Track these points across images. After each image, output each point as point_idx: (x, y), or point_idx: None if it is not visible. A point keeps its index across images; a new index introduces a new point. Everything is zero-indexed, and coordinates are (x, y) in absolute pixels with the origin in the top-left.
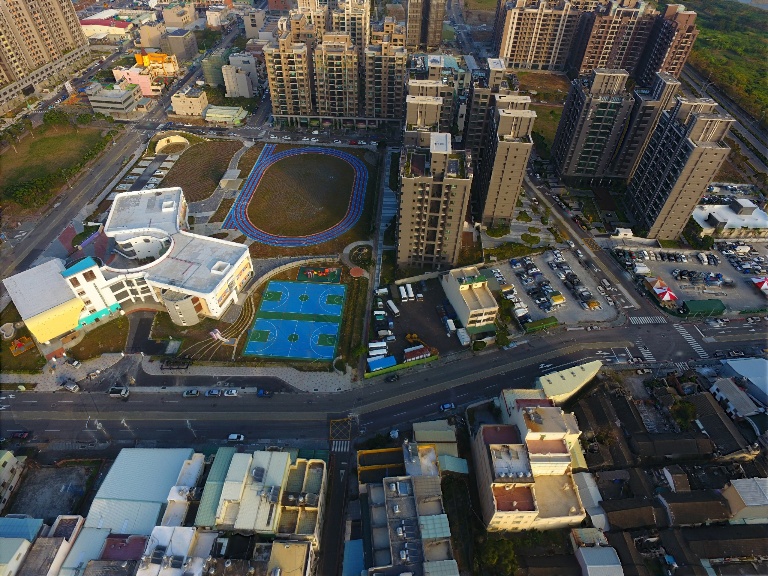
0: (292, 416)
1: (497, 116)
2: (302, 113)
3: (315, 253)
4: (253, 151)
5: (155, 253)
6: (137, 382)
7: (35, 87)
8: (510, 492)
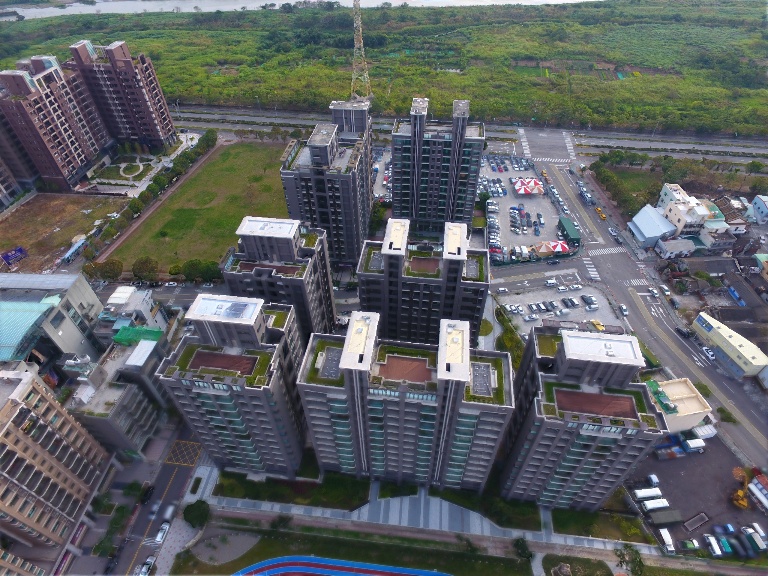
0: None
1: None
2: None
3: None
4: None
5: None
6: None
7: None
8: None
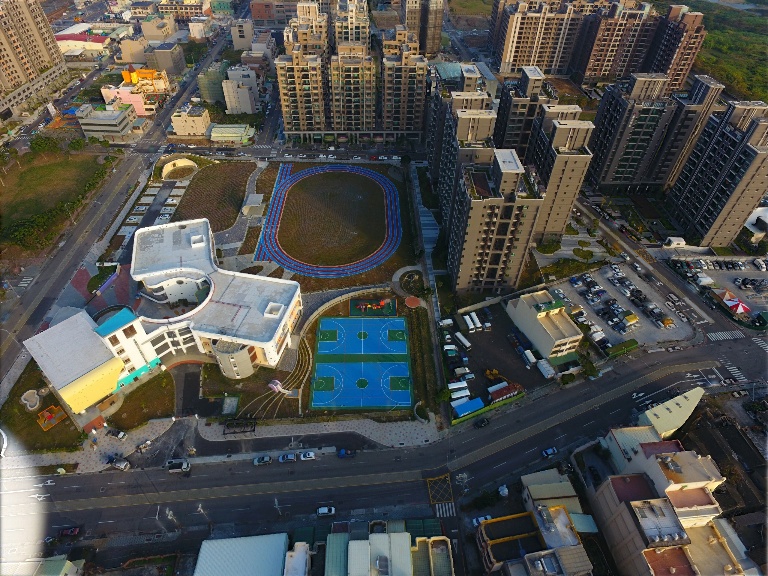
0: (383, 478)
1: (545, 127)
2: (316, 129)
3: (363, 283)
4: (269, 172)
5: (188, 295)
6: (197, 451)
7: (13, 110)
8: (663, 556)
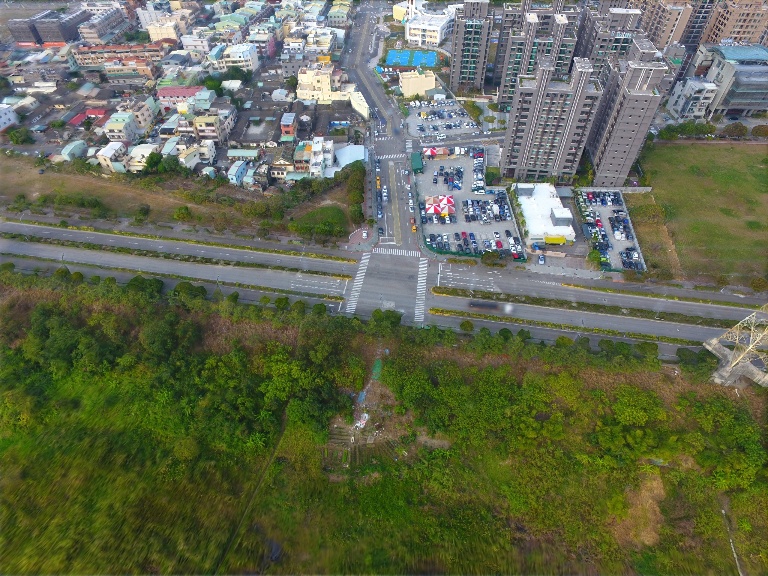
0: (358, 59)
1: None
2: None
3: None
4: None
5: None
6: None
7: None
8: None
